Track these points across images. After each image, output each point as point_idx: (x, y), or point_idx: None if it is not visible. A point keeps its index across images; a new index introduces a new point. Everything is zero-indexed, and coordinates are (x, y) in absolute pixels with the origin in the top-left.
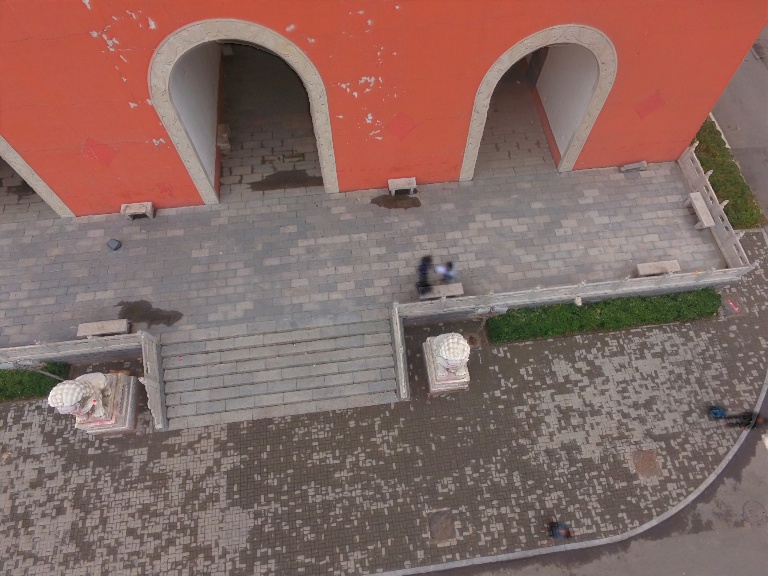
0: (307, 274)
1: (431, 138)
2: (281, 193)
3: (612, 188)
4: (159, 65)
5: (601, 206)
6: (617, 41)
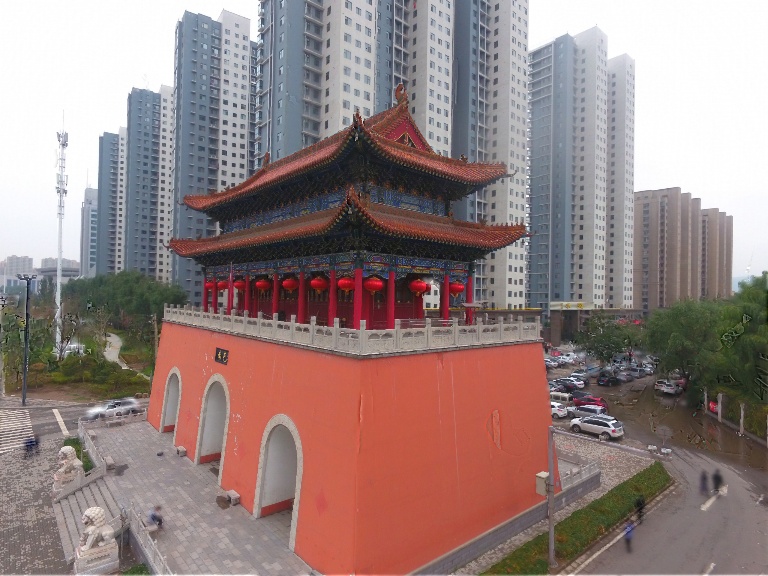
0: (156, 494)
1: (249, 467)
2: None
3: (289, 575)
4: None
5: (265, 574)
6: None
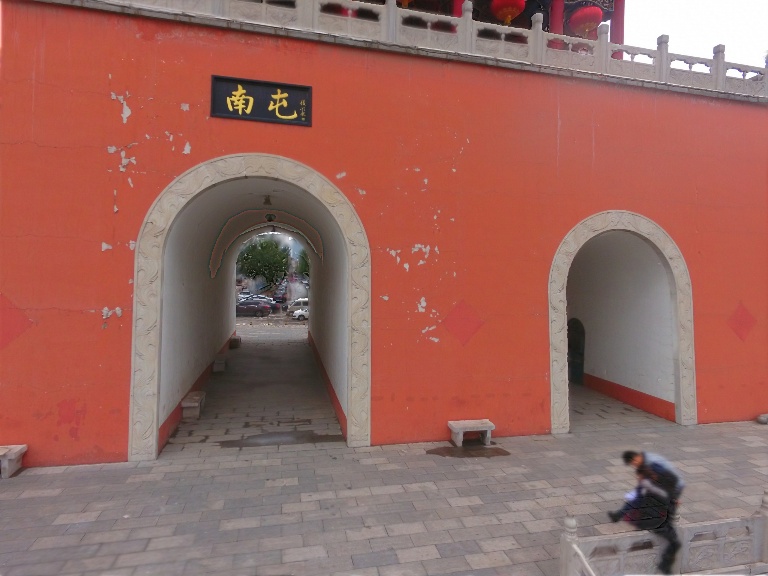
0: (321, 538)
1: (502, 349)
2: (272, 448)
3: None
4: (172, 196)
5: None
6: (673, 236)
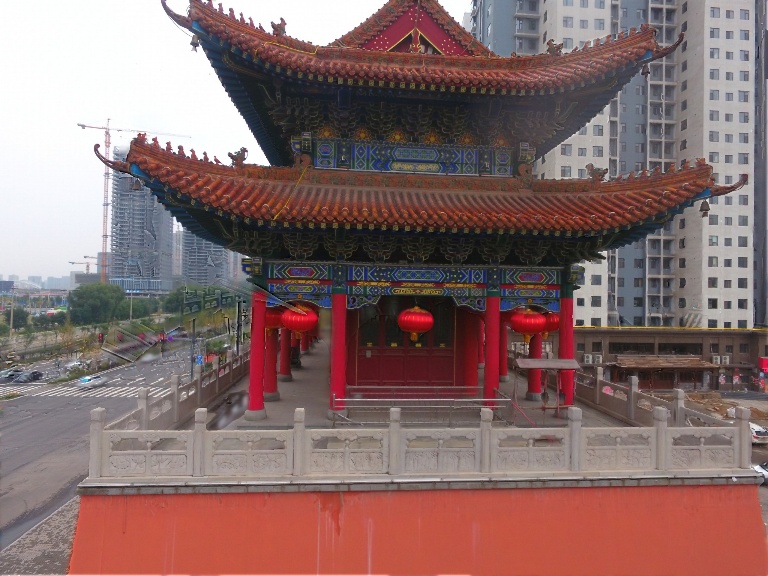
0: None
1: None
2: None
3: None
4: None
5: None
6: None
